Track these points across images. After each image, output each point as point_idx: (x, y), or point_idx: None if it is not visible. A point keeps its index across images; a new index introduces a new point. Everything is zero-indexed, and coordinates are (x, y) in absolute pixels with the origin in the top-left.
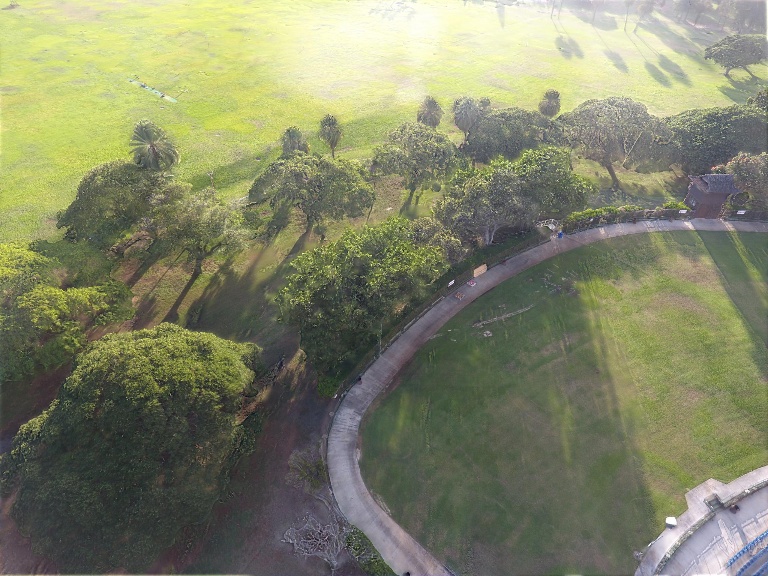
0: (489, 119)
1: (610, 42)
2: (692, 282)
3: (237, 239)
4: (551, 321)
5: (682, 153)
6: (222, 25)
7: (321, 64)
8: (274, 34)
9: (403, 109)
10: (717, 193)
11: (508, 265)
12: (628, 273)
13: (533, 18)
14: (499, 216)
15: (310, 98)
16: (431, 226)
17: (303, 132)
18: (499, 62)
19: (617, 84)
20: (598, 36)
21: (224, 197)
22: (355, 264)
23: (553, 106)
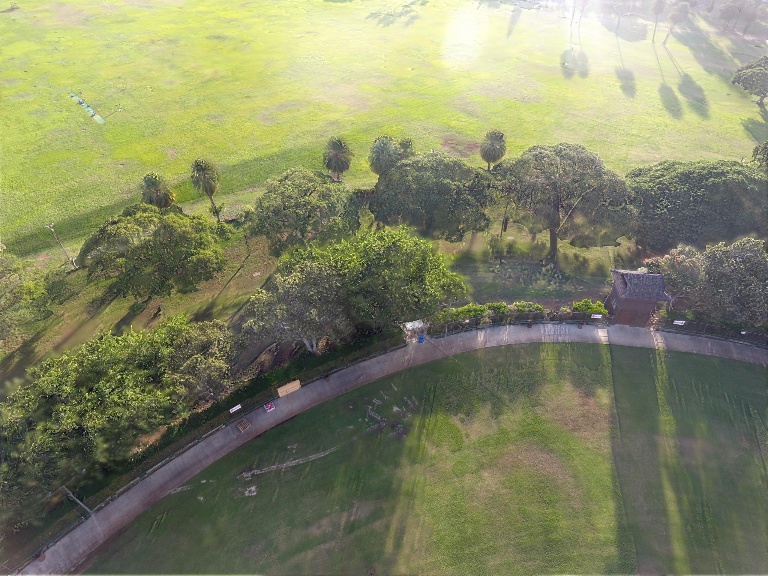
0: (398, 168)
1: (629, 56)
2: (569, 430)
3: (7, 325)
4: (346, 478)
5: (638, 222)
6: (203, 31)
7: (280, 80)
8: (250, 43)
9: (341, 139)
10: (638, 300)
11: (332, 381)
12: (487, 406)
13: (549, 25)
14: (290, 333)
15: (245, 122)
16: (198, 341)
17: (213, 166)
18: (482, 81)
19: (613, 112)
20: (617, 48)
21: (26, 265)
22: (39, 407)
23: (495, 149)
